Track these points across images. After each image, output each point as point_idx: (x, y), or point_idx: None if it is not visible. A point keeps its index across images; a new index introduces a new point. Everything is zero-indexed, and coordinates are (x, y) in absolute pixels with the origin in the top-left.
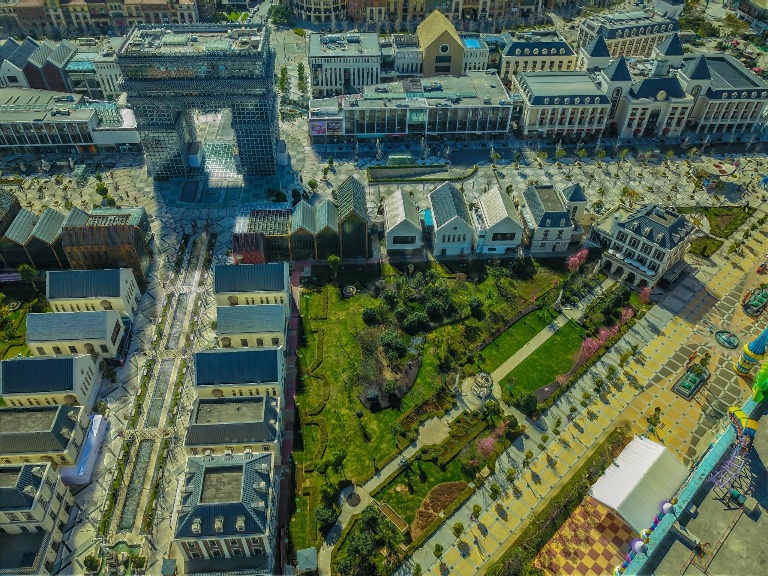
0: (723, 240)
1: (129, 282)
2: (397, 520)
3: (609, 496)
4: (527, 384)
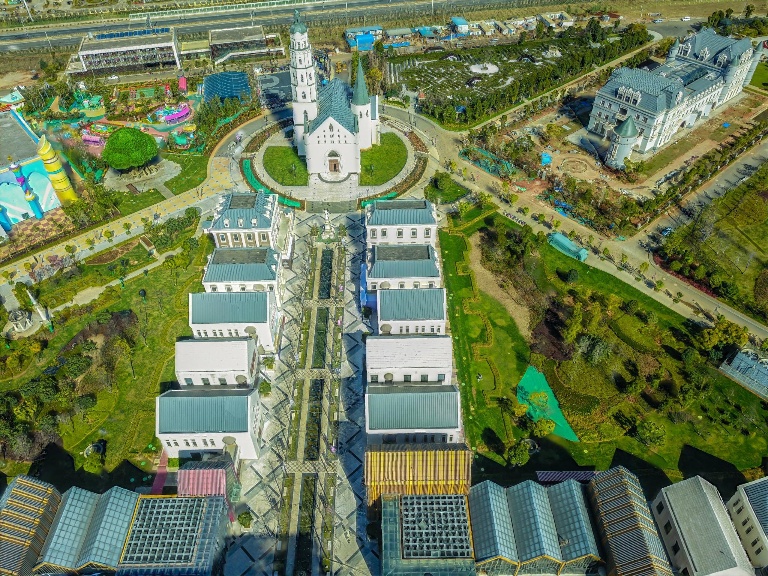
0: None
1: None
2: (145, 240)
3: None
4: None
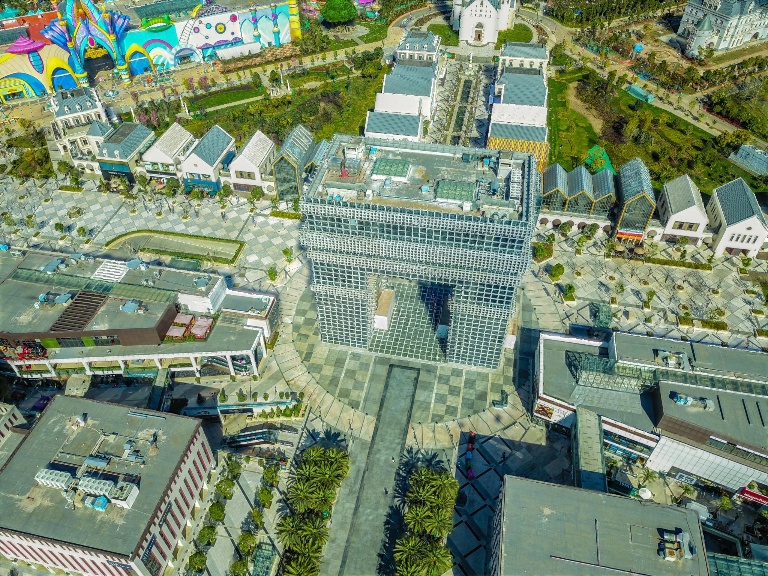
0: (5, 141)
1: None
2: None
3: (257, 46)
4: (248, 93)
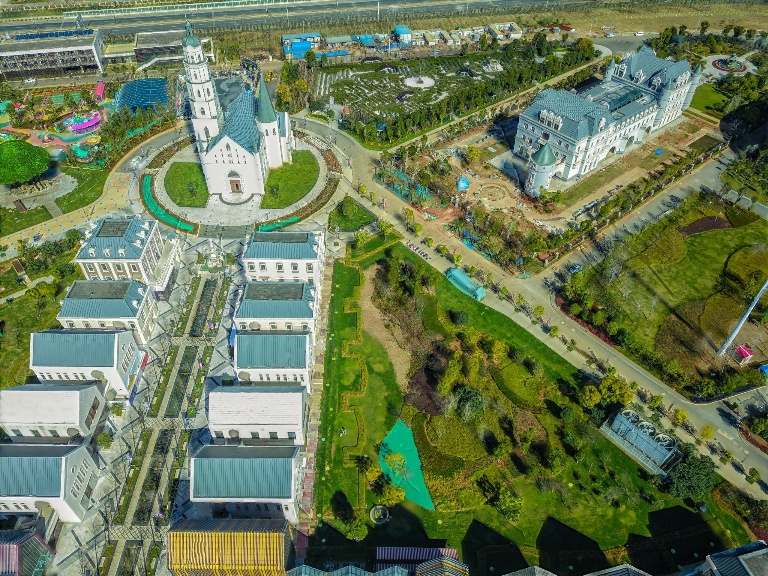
0: None
1: None
2: (16, 265)
3: None
4: None
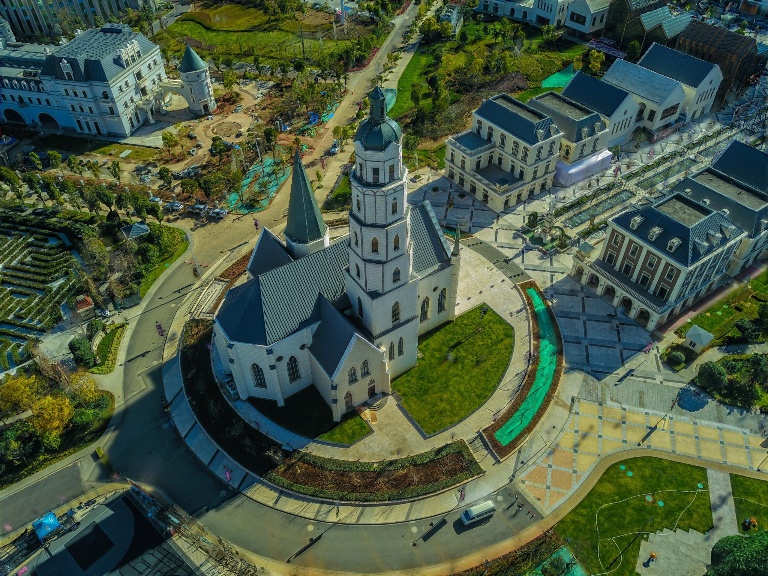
0: None
1: (712, 86)
2: None
3: None
4: None
